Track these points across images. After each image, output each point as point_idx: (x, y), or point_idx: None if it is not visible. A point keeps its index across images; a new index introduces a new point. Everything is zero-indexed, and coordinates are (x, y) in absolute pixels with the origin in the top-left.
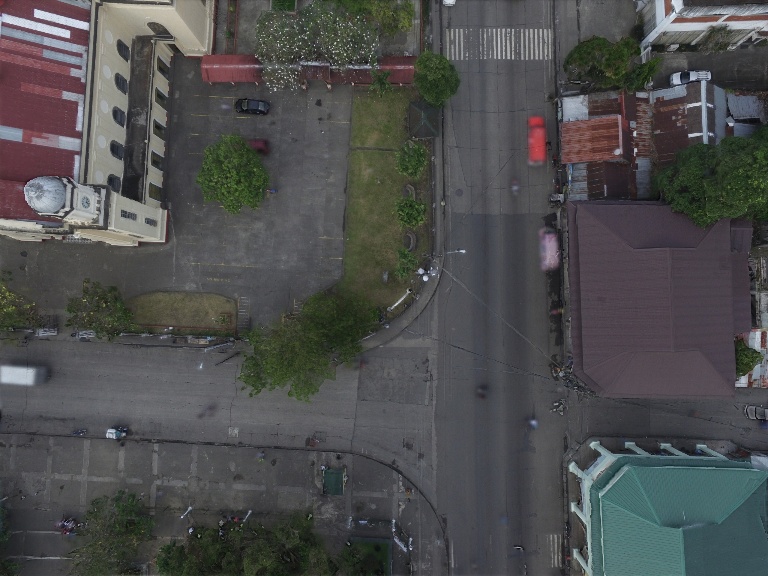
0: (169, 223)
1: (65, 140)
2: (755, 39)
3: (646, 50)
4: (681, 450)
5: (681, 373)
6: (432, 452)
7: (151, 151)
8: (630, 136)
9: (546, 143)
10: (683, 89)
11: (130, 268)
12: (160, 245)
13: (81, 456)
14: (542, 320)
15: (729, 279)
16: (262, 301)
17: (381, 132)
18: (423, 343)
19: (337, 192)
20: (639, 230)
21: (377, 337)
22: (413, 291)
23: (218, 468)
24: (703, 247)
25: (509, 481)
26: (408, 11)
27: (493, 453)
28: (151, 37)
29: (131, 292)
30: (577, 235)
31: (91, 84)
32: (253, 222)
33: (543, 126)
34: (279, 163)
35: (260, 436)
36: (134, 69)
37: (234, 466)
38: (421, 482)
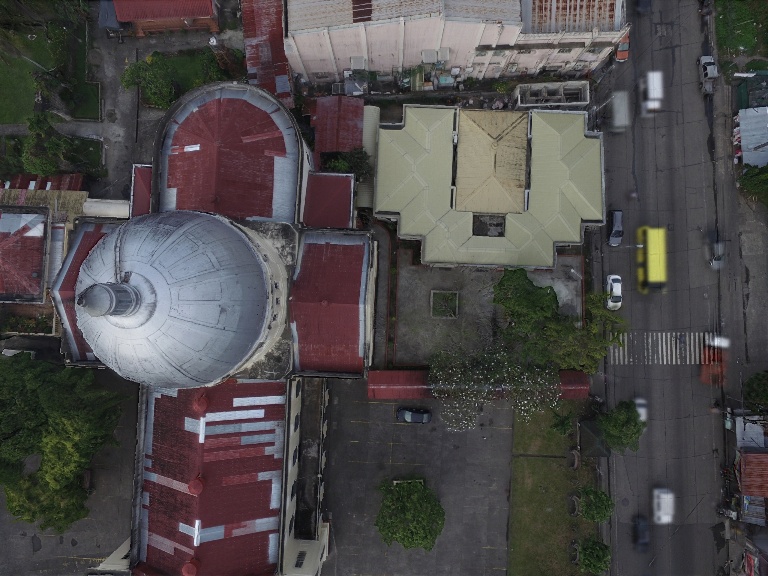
0: (330, 534)
1: (261, 522)
2: None
3: None
4: None
5: None
6: None
7: None
8: None
9: (713, 450)
10: None
11: None
12: None
13: None
14: None
15: None
16: None
17: (544, 439)
18: None
19: (500, 500)
20: None
21: None
22: None
23: None
24: None
25: None
26: (595, 359)
27: None
28: None
29: None
30: None
31: (286, 463)
32: None
33: (710, 433)
34: (441, 471)
35: None
36: (305, 399)
37: None
38: None
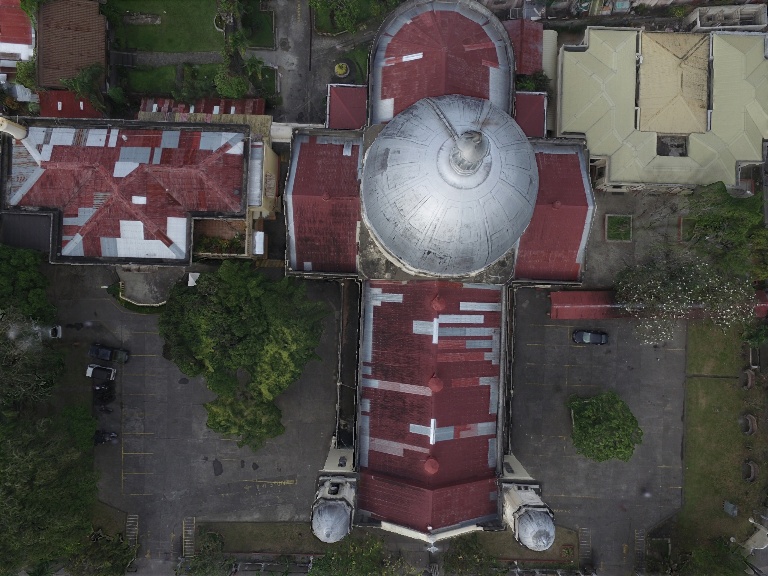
0: None
1: (481, 426)
2: None
3: None
4: None
5: None
6: None
7: None
8: None
9: None
10: None
11: None
12: None
13: None
14: None
15: None
16: (603, 531)
17: (717, 359)
18: (766, 572)
19: (674, 420)
20: None
21: None
22: (755, 521)
23: None
24: None
25: None
26: None
27: None
28: None
29: None
30: None
31: None
32: None
33: None
34: (616, 392)
35: None
36: None
37: None
38: None
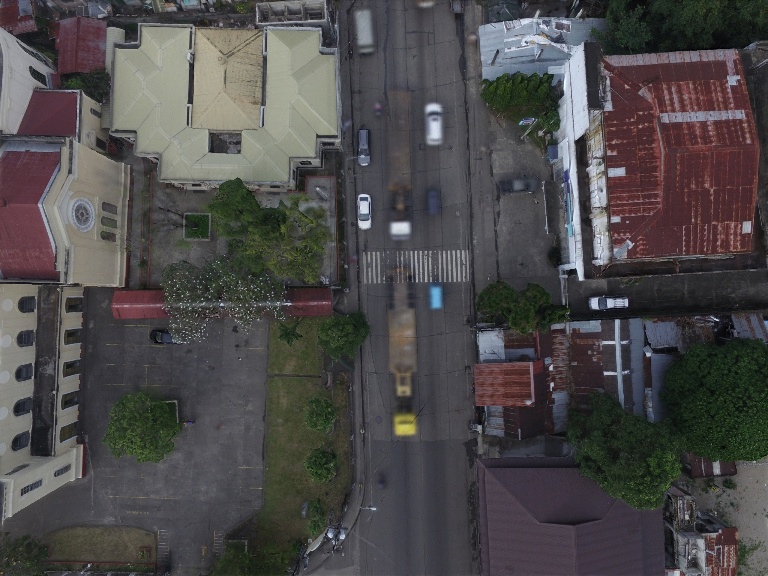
0: (86, 456)
1: None
2: None
3: (563, 276)
4: None
5: None
6: None
7: (61, 397)
8: (545, 373)
9: (466, 367)
10: (598, 325)
11: (48, 503)
12: (77, 479)
13: None
14: (464, 548)
15: (639, 542)
16: (182, 533)
17: (299, 358)
18: (345, 574)
19: (256, 420)
20: (546, 499)
21: None
22: None
23: None
24: (610, 516)
25: None
26: (313, 267)
27: None
28: None
29: (49, 527)
30: None
31: None
32: (171, 453)
33: (462, 350)
34: (196, 392)
35: None
36: (41, 317)
37: None
38: None
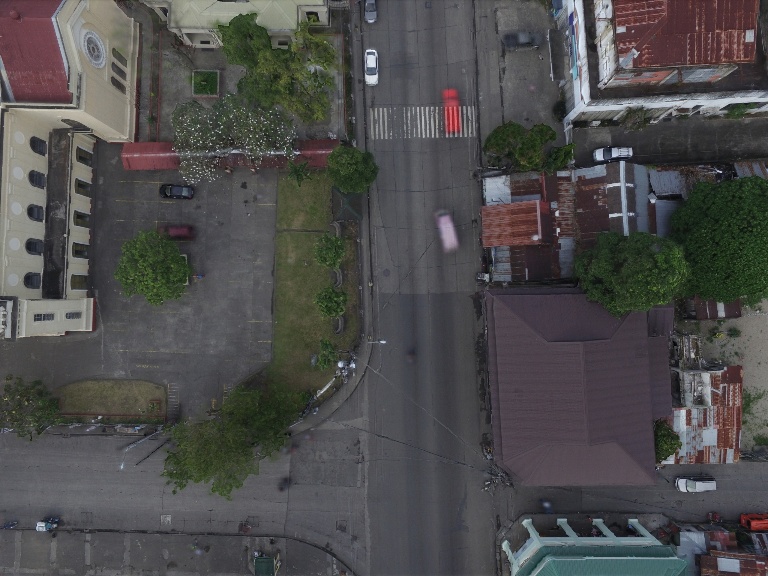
0: (96, 311)
1: None
2: (675, 115)
3: (568, 127)
4: (613, 525)
5: (599, 463)
6: (365, 534)
7: (72, 243)
8: (551, 217)
9: (472, 221)
10: (603, 169)
11: (58, 357)
12: (88, 333)
13: (13, 548)
14: (472, 399)
15: (646, 366)
16: (192, 387)
17: (307, 213)
18: (354, 425)
19: (265, 275)
20: (554, 321)
21: (308, 420)
22: None
23: (151, 556)
24: (618, 337)
25: (443, 561)
26: (322, 103)
27: (426, 533)
28: (68, 130)
29: (59, 381)
30: (494, 326)
31: None
32: (181, 307)
33: (469, 204)
34: (206, 247)
35: (193, 523)
36: (52, 162)
37: (167, 554)
38: (355, 564)
